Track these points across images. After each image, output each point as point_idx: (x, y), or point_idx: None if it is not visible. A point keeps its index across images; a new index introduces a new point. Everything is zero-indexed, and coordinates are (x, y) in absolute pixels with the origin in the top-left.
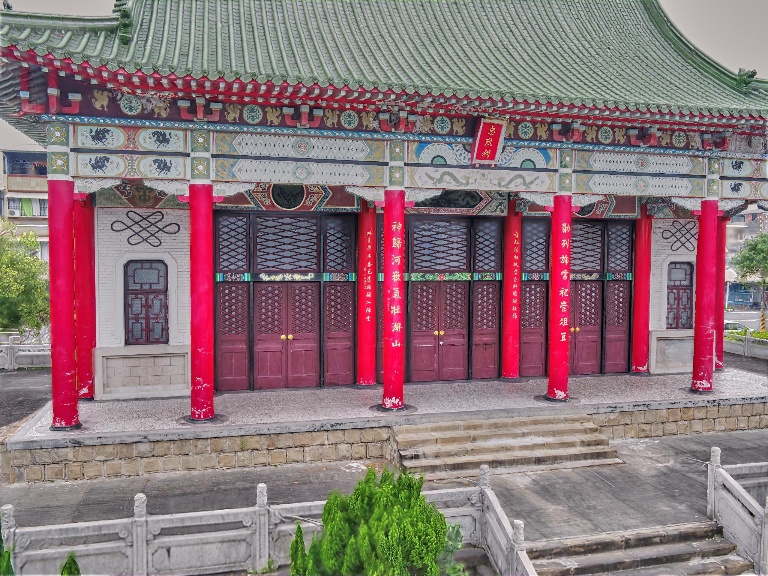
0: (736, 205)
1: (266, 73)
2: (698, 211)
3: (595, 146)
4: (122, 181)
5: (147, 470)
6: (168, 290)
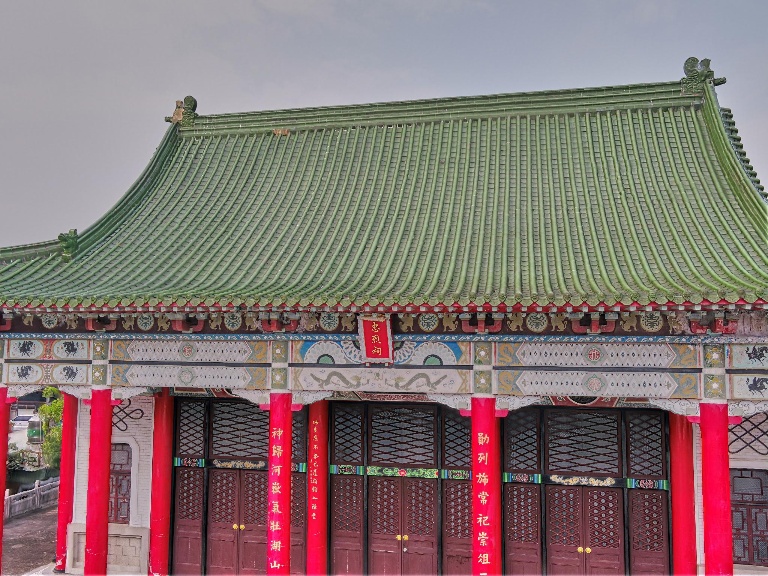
0: (764, 409)
1: (105, 296)
2: (695, 417)
3: (518, 337)
4: (43, 386)
5: None
6: (131, 472)
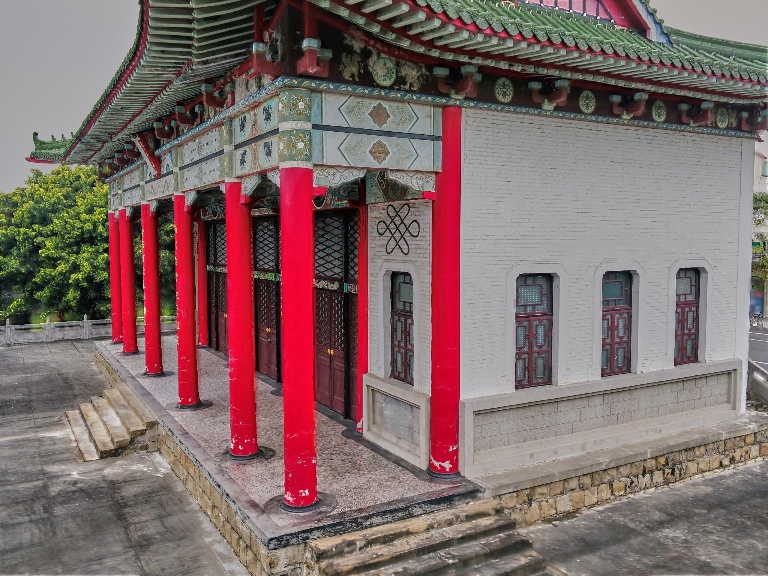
0: (253, 184)
1: None
2: None
3: (176, 140)
4: None
5: (102, 371)
6: None
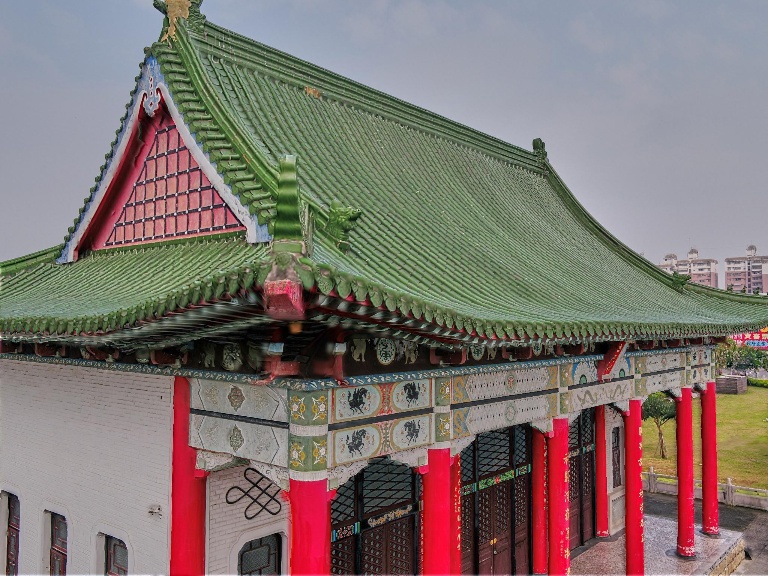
0: None
1: (576, 323)
2: (681, 397)
3: (652, 352)
4: None
5: None
6: (287, 574)
